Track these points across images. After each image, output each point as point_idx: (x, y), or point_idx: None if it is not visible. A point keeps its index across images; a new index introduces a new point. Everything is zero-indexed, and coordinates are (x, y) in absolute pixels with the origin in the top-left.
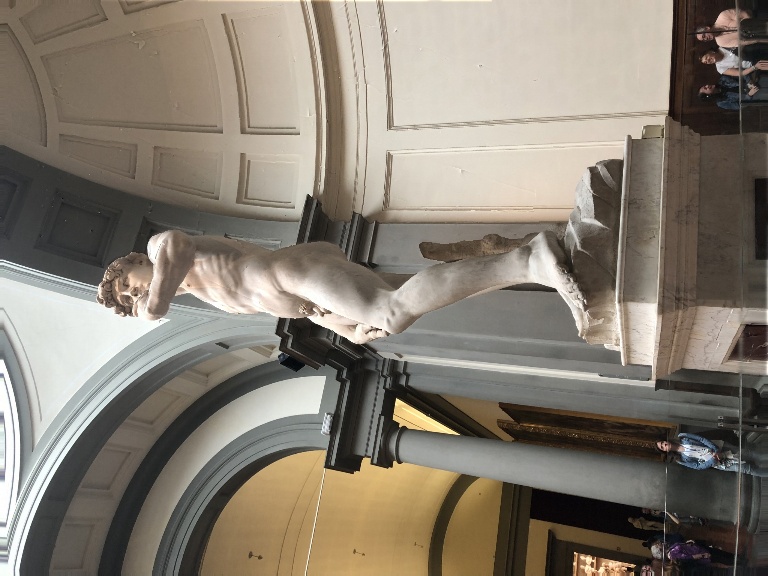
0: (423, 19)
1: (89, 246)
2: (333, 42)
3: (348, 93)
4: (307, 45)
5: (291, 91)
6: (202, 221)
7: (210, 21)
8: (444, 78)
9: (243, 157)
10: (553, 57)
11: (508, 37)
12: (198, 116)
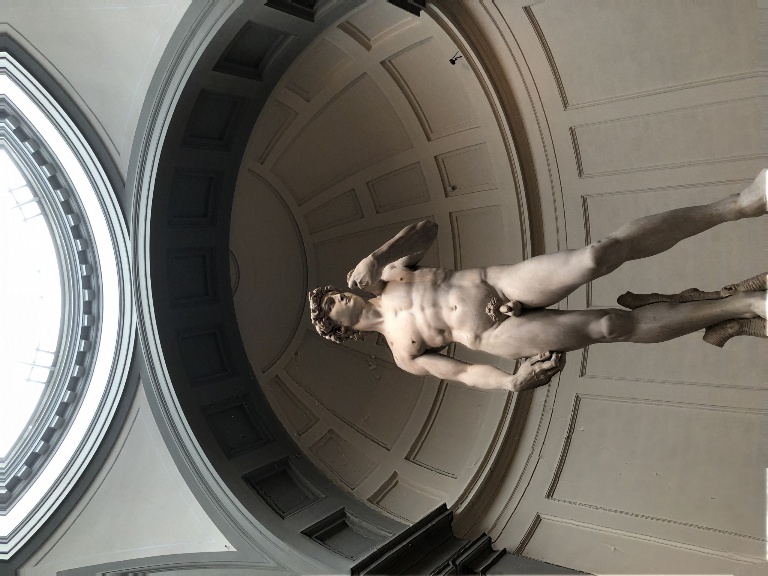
0: (611, 426)
1: (232, 443)
2: (523, 419)
3: (519, 458)
4: (502, 410)
5: (466, 447)
6: (330, 490)
7: (431, 377)
8: (617, 473)
9: (394, 477)
10: (735, 483)
11: (690, 459)
12: (377, 433)
